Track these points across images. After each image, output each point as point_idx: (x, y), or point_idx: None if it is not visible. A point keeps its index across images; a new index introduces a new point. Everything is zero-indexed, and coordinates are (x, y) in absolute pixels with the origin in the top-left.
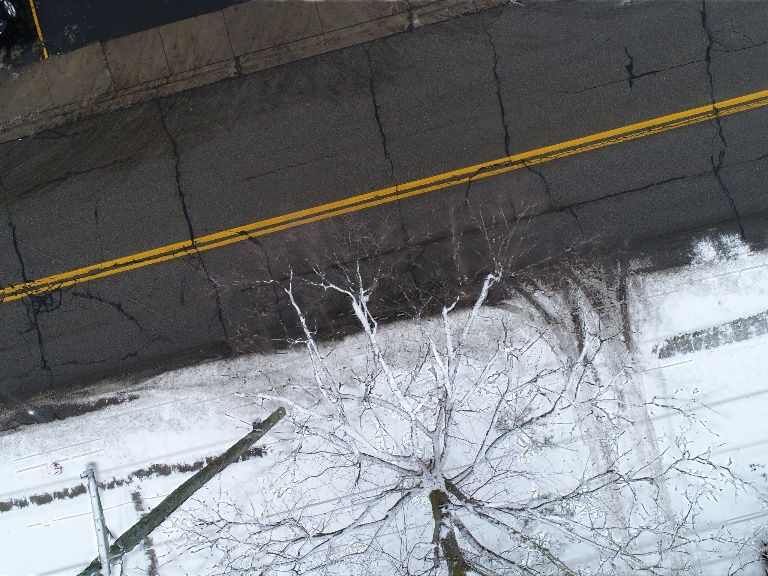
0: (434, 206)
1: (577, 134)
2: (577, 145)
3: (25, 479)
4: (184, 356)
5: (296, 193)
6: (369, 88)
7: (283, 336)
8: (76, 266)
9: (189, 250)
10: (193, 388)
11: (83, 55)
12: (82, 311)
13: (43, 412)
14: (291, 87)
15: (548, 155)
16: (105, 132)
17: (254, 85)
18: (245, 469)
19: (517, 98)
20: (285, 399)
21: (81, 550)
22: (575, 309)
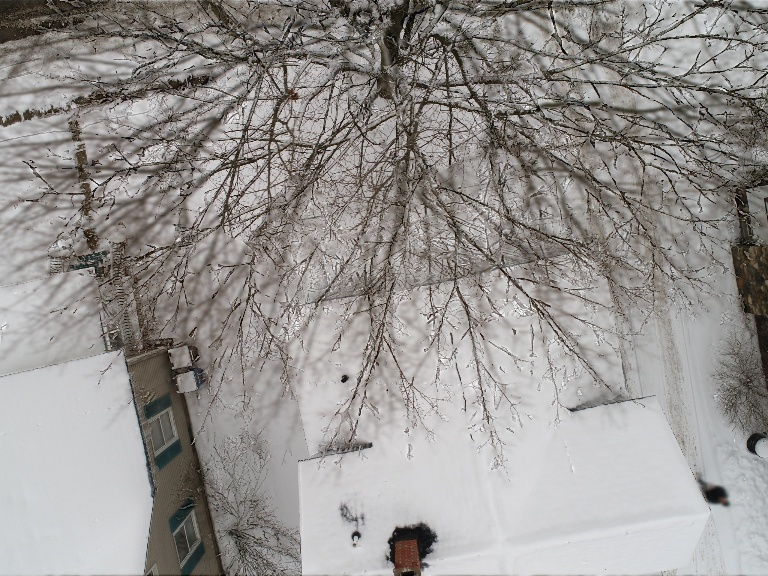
0: None
1: None
2: None
3: None
4: None
5: None
6: None
7: None
8: None
9: None
10: (142, 10)
11: None
12: None
13: None
14: None
15: None
16: None
17: None
18: (191, 94)
19: None
20: None
21: (11, 176)
22: None
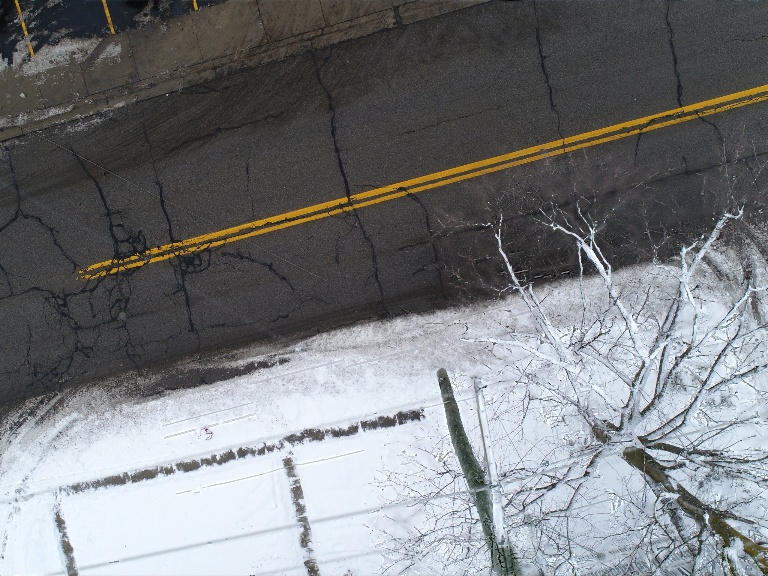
0: (602, 159)
1: (753, 83)
2: (753, 95)
3: (173, 445)
4: (338, 317)
5: (458, 147)
6: (535, 37)
7: (442, 296)
8: (226, 225)
9: (345, 207)
10: (347, 350)
11: (235, 6)
12: (232, 272)
13: (189, 377)
14: (453, 37)
15: (723, 105)
16: (257, 86)
17: (414, 36)
18: (404, 433)
19: (690, 46)
20: (521, 343)
21: (233, 517)
22: (748, 265)
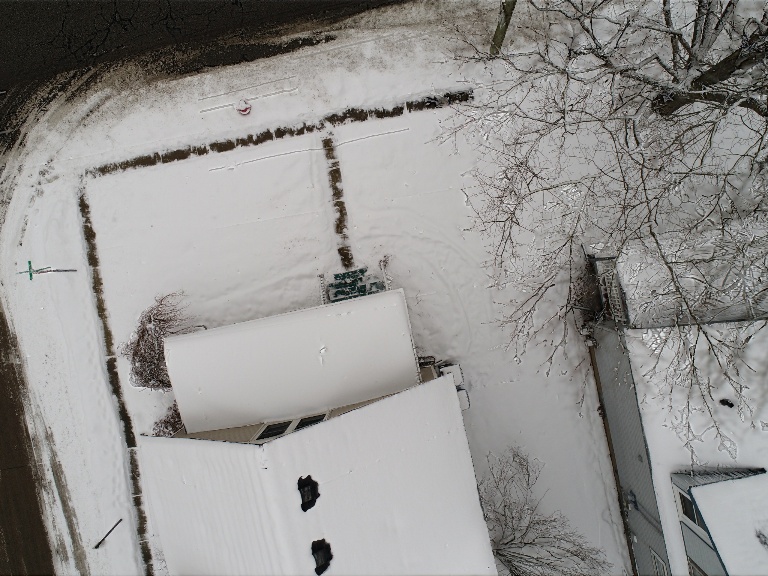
0: None
1: None
2: None
3: (208, 120)
4: None
5: None
6: None
7: None
8: None
9: None
10: (397, 27)
11: None
12: None
13: (230, 53)
14: None
15: None
16: None
17: None
18: (451, 111)
19: None
20: None
21: (267, 194)
22: None
